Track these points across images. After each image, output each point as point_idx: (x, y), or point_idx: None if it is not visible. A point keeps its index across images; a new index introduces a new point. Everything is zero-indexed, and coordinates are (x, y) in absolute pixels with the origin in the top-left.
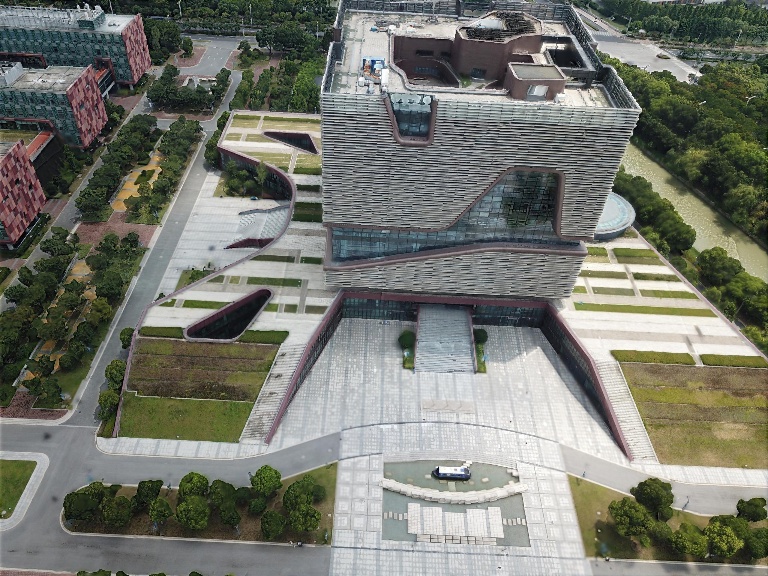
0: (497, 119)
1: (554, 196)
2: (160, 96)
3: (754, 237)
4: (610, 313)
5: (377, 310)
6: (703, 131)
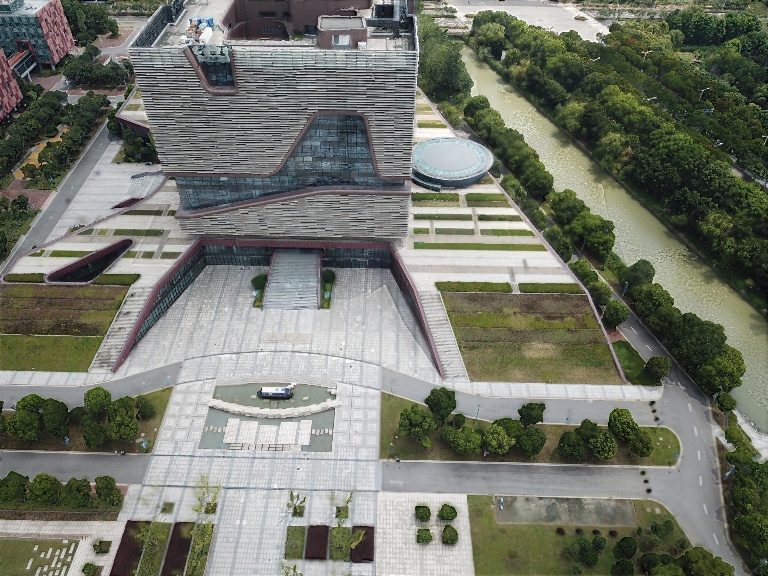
0: (290, 66)
1: (366, 138)
2: (77, 74)
3: (622, 183)
4: (446, 250)
5: (236, 256)
6: (588, 85)
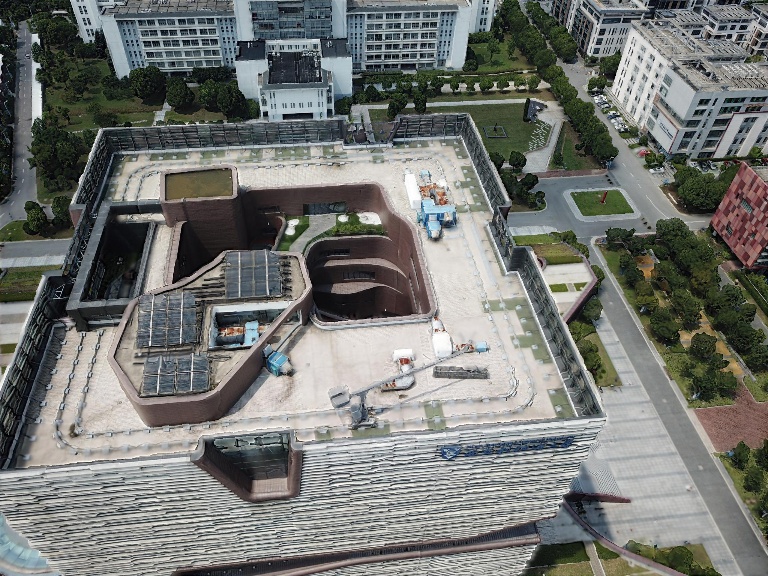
0: None
1: None
2: None
3: None
4: None
5: None
6: None
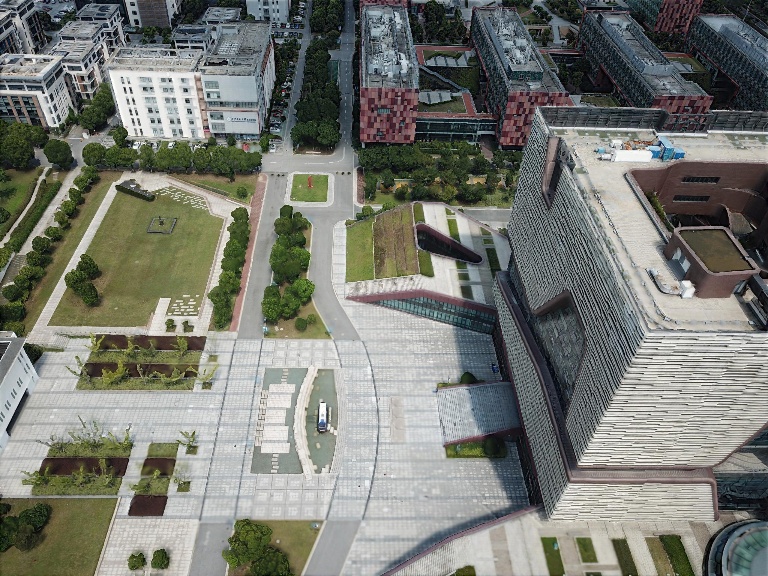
0: None
1: None
2: None
3: None
4: None
5: None
6: None
